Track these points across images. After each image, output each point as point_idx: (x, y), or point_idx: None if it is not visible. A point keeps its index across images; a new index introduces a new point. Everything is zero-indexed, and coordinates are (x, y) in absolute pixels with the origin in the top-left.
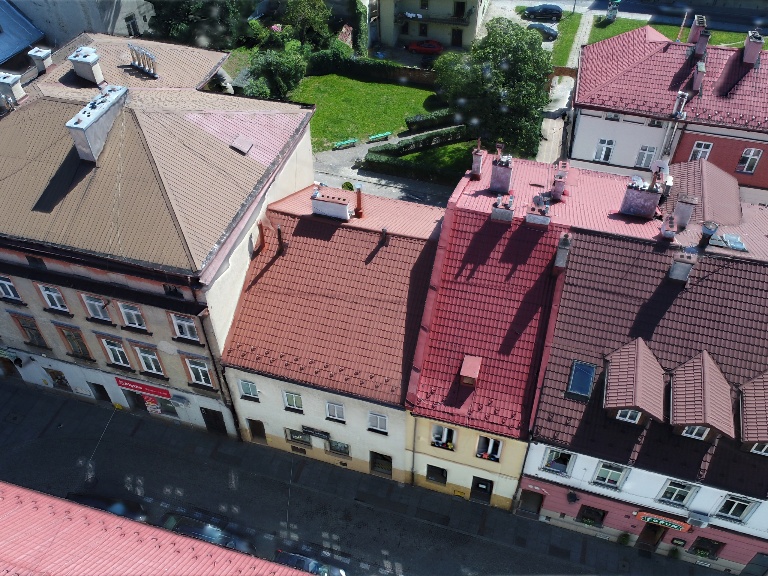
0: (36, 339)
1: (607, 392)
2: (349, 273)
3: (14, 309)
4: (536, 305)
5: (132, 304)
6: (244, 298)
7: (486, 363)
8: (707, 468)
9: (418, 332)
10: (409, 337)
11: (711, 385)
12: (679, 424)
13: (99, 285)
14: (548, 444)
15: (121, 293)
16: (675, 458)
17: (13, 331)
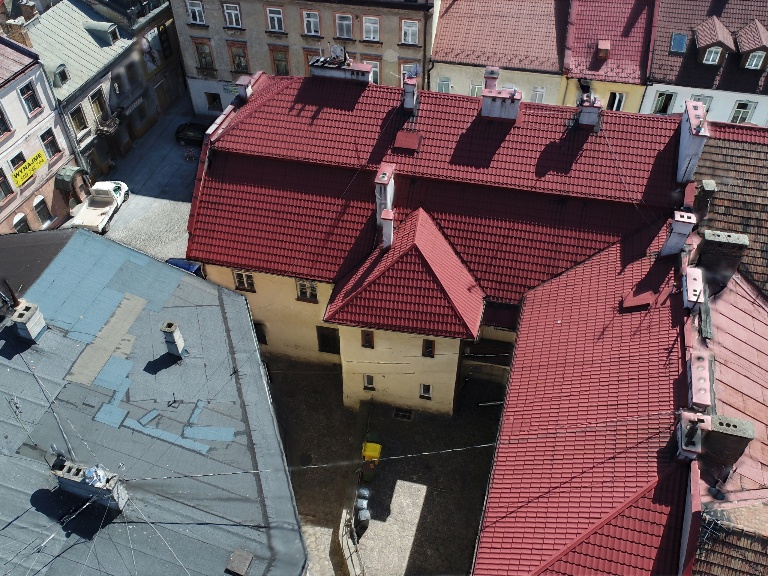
0: (282, 71)
1: (698, 41)
2: (512, 1)
3: (274, 42)
4: (644, 5)
5: (375, 16)
6: (441, 21)
7: (613, 43)
8: (763, 84)
9: (565, 30)
10: (559, 34)
11: (763, 33)
12: (746, 51)
13: (355, 1)
14: (660, 83)
15: (373, 3)
16: (742, 81)
17: (265, 66)
